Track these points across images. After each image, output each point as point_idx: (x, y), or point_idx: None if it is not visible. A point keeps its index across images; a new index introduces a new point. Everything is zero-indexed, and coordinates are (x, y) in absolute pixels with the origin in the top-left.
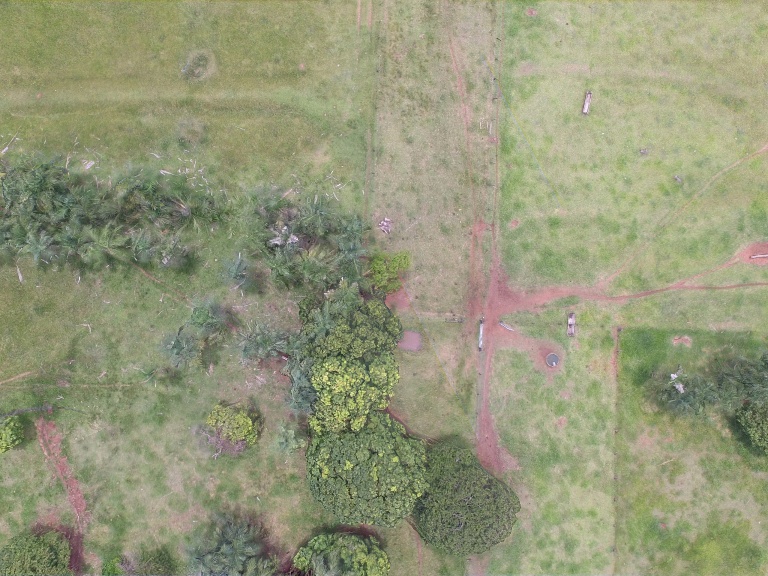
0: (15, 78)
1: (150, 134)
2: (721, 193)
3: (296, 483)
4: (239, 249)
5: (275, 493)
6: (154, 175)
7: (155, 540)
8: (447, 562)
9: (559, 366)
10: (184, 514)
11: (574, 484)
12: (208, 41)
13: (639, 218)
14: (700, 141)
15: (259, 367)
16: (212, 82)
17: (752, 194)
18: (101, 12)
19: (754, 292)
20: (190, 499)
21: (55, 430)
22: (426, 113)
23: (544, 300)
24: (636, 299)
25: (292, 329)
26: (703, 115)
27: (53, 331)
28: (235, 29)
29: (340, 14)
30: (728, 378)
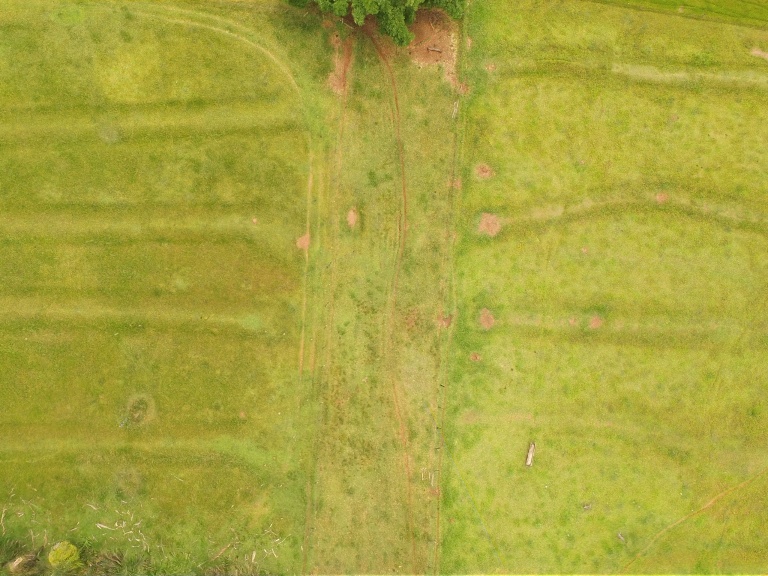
0: None
1: (87, 484)
2: (665, 552)
3: None
4: None
5: None
6: (90, 529)
7: None
8: None
9: None
10: None
11: None
12: (148, 385)
13: None
14: (645, 496)
15: None
16: (151, 429)
17: (697, 553)
18: (41, 355)
19: None
20: None
21: None
22: (368, 461)
23: None
24: None
25: None
26: (648, 468)
27: None
28: (176, 374)
29: (282, 359)
30: None
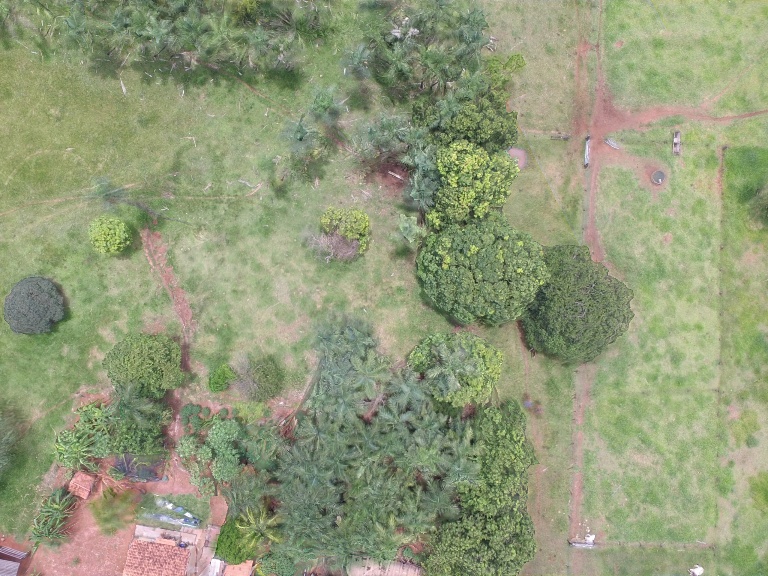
0: None
1: None
2: None
3: (403, 295)
4: (344, 65)
5: (382, 305)
6: None
7: (261, 350)
8: (553, 374)
9: (664, 184)
10: (291, 325)
11: (680, 299)
12: None
13: (744, 40)
14: None
15: (365, 181)
16: None
17: None
18: None
19: None
20: (297, 310)
21: (160, 240)
22: None
23: (649, 119)
24: (740, 120)
25: (398, 144)
26: None
27: (157, 143)
28: None
29: None
30: None
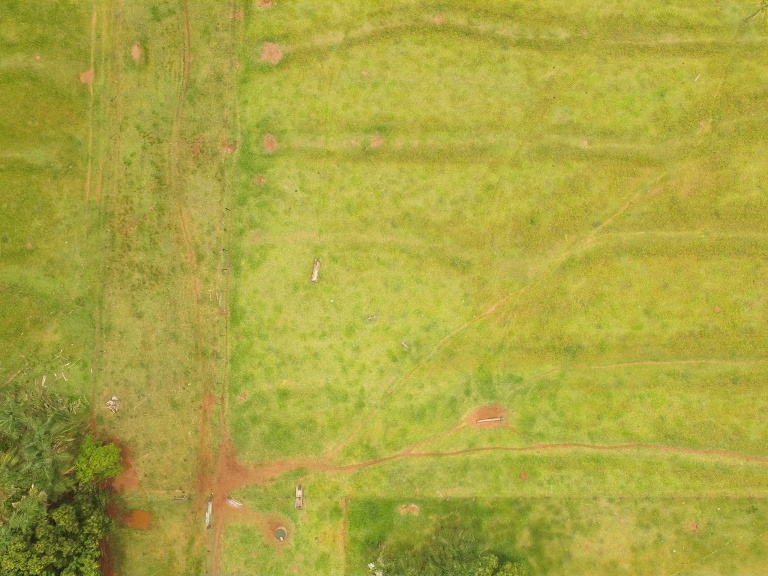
0: None
1: None
2: (448, 357)
3: None
4: None
5: None
6: None
7: None
8: None
9: (288, 539)
10: None
11: None
12: None
13: (366, 386)
14: (428, 305)
15: None
16: None
17: (479, 357)
18: None
19: (480, 457)
20: None
21: None
22: (157, 286)
23: (272, 474)
24: (364, 468)
25: None
26: (431, 278)
27: None
28: None
29: (68, 190)
30: (429, 562)
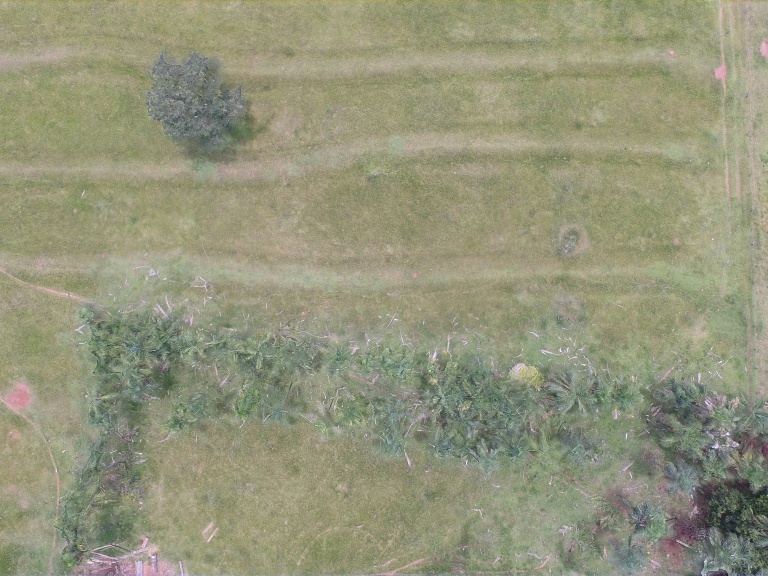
0: (388, 257)
1: (528, 312)
2: None
3: None
4: (626, 430)
5: None
6: (535, 355)
7: None
8: None
9: None
10: None
11: None
12: (579, 216)
13: None
14: None
15: (653, 550)
16: (585, 258)
17: None
18: (471, 188)
19: None
20: None
21: None
22: None
23: None
24: None
25: (683, 511)
26: None
27: (445, 517)
28: (606, 203)
29: (711, 186)
30: None
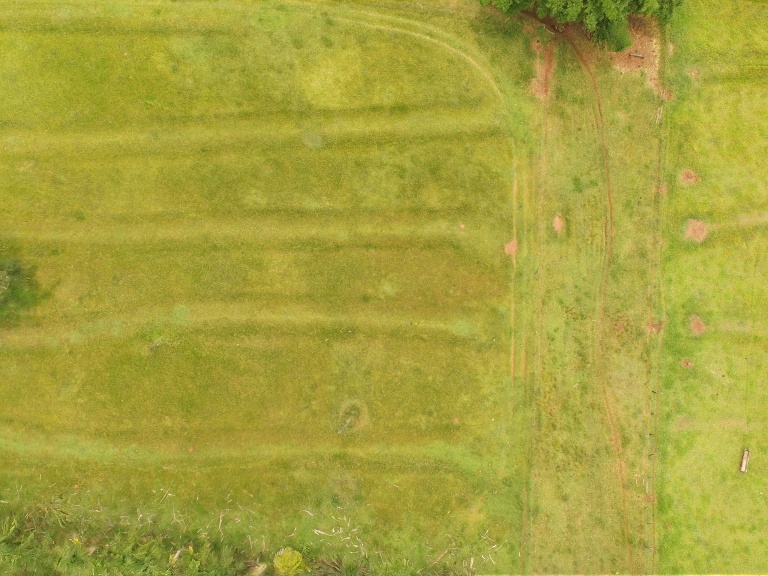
0: (166, 429)
1: (303, 490)
2: None
3: None
4: None
5: None
6: (308, 535)
7: None
8: None
9: None
10: None
11: None
12: (360, 391)
13: None
14: None
15: None
16: (365, 435)
17: None
18: (253, 360)
19: None
20: None
21: None
22: (581, 467)
23: None
24: None
25: None
26: None
27: None
28: (388, 380)
29: (494, 365)
30: None
